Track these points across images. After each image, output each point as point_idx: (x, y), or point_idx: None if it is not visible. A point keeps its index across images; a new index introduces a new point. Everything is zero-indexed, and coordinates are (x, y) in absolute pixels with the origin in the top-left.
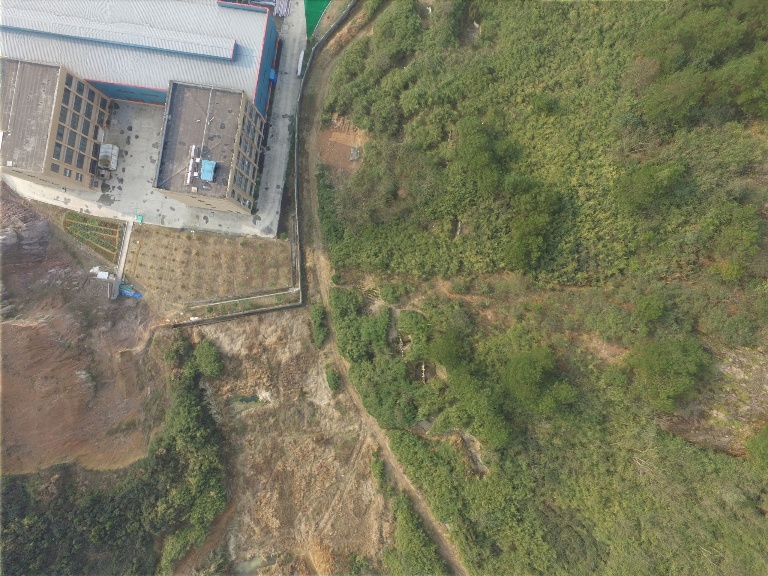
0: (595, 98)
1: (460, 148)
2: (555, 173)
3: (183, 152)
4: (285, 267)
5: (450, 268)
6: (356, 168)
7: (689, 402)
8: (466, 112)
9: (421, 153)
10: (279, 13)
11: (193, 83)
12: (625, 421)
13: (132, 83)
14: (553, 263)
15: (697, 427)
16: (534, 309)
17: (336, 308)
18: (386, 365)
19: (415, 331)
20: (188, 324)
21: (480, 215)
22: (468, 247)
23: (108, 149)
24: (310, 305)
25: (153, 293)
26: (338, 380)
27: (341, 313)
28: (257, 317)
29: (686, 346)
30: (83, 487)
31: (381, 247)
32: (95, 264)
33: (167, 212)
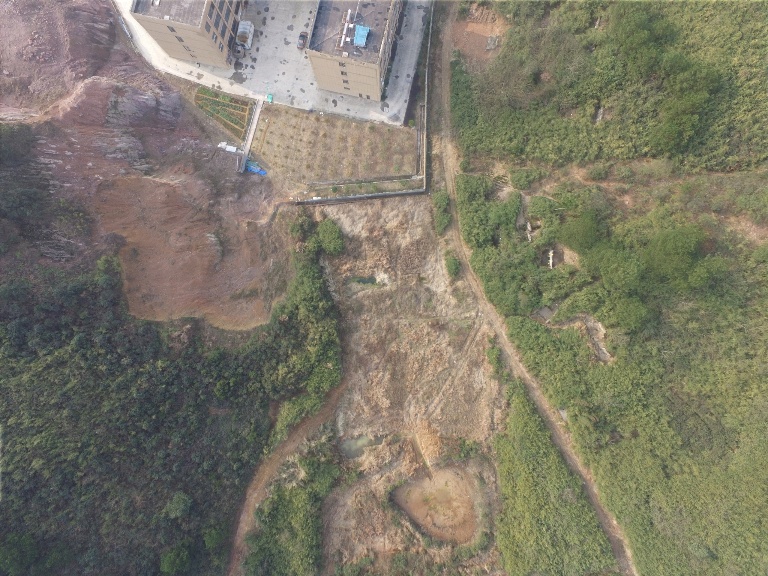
0: None
1: (611, 31)
2: (713, 54)
3: (337, 17)
4: (410, 154)
5: (589, 153)
6: (492, 57)
7: None
8: None
9: (569, 36)
10: None
11: None
12: None
13: None
14: (701, 147)
15: None
16: (681, 190)
17: (464, 192)
18: (514, 248)
19: (548, 214)
20: (311, 203)
21: (627, 99)
22: (610, 132)
23: (247, 26)
24: (433, 193)
25: (277, 172)
26: (459, 266)
27: (469, 197)
28: (380, 201)
29: None
30: (210, 342)
31: (517, 132)
32: (223, 139)
33: (297, 93)
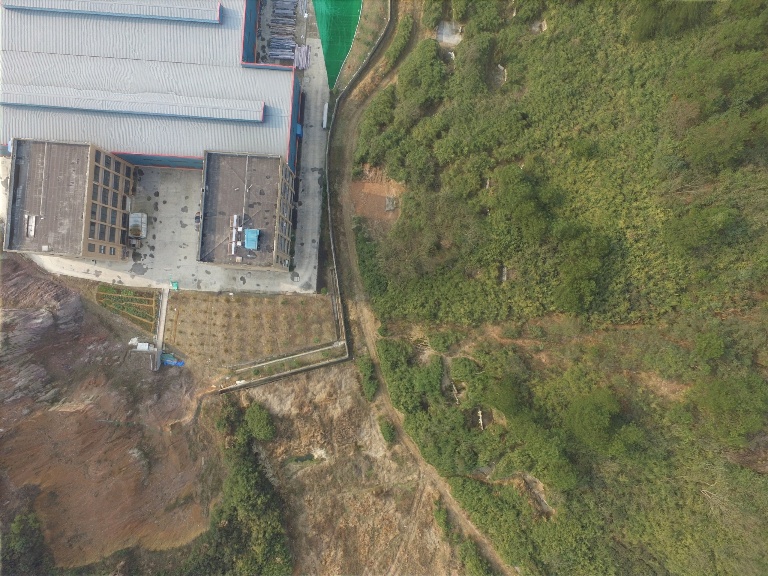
0: (635, 141)
1: (501, 196)
2: (601, 216)
3: (224, 222)
4: (328, 322)
5: (500, 314)
6: (393, 218)
7: (755, 435)
8: (503, 158)
9: (462, 203)
10: (299, 66)
11: (229, 152)
12: (690, 455)
13: (160, 152)
14: (604, 304)
15: (764, 457)
16: (591, 351)
17: (386, 361)
18: (443, 415)
19: (470, 379)
20: (235, 388)
21: (527, 261)
22: (516, 292)
23: (137, 218)
24: (357, 358)
25: (195, 359)
26: (393, 432)
27: (391, 365)
28: (304, 375)
29: (750, 382)
30: (149, 570)
31: (427, 297)
32: (133, 335)
33: (203, 276)
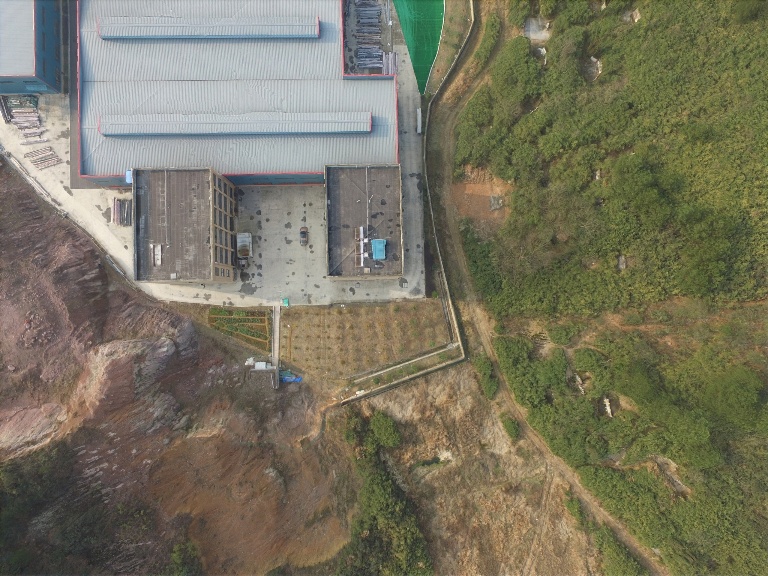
0: (751, 121)
1: (616, 185)
2: (722, 198)
3: (348, 235)
4: (440, 325)
5: (621, 302)
6: (500, 217)
7: None
8: (613, 149)
9: (576, 196)
10: (388, 74)
11: (349, 165)
12: None
13: (270, 170)
14: (729, 283)
15: None
16: (722, 331)
17: (507, 358)
18: (571, 406)
19: (598, 369)
20: (355, 399)
21: (647, 247)
22: (637, 279)
23: (245, 238)
24: (472, 358)
25: (312, 374)
26: (518, 427)
27: (513, 362)
28: (423, 379)
29: None
30: None
31: (545, 292)
32: (248, 355)
33: (312, 290)
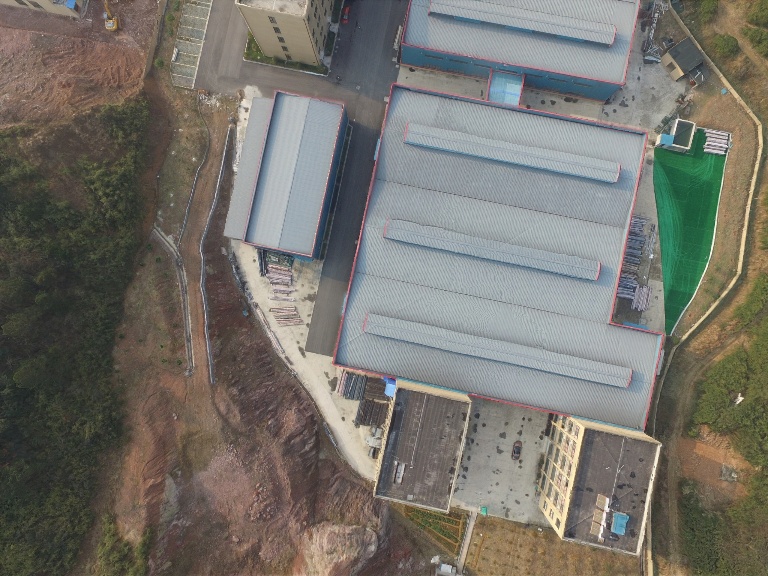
0: None
1: None
2: None
3: (590, 499)
4: (634, 573)
5: None
6: (729, 490)
7: None
8: None
9: None
10: (638, 307)
11: (609, 432)
12: None
13: (513, 398)
14: None
15: None
16: None
17: None
18: None
19: None
20: None
21: None
22: None
23: None
24: None
25: None
26: None
27: None
28: None
29: None
30: None
31: None
32: (435, 553)
33: (512, 505)
